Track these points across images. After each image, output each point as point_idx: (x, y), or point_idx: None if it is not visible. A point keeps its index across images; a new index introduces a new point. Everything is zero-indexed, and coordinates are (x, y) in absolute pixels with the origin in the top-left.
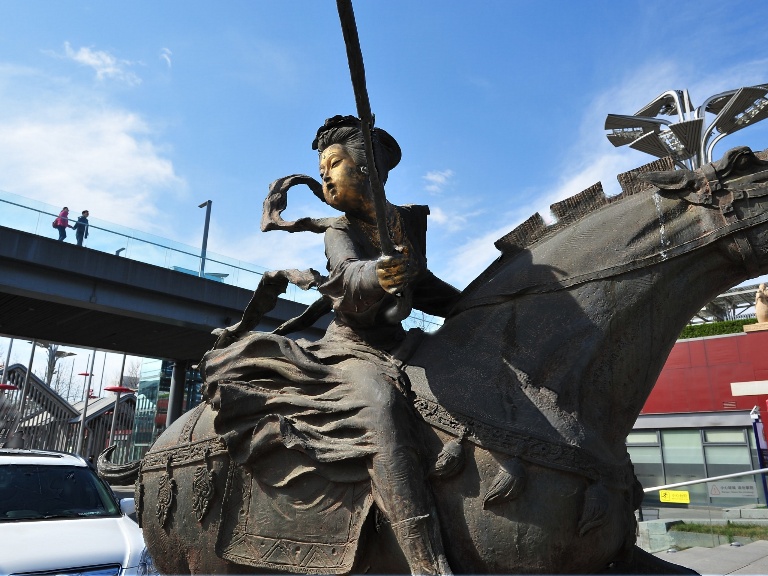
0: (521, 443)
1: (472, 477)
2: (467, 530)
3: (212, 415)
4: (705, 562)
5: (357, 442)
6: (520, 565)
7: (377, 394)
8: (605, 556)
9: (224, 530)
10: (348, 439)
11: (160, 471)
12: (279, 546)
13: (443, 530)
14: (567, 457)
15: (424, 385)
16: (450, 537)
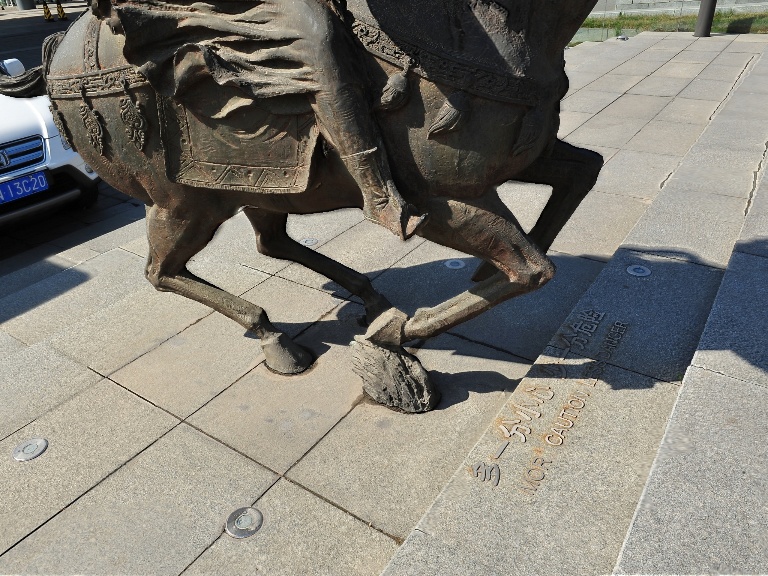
0: (468, 76)
1: (417, 109)
2: (412, 156)
3: (114, 38)
4: (590, 62)
5: (296, 77)
6: (458, 182)
7: (312, 25)
8: None
9: (170, 159)
10: (284, 70)
11: (76, 100)
12: (230, 171)
13: (389, 157)
14: (512, 89)
15: (362, 3)
16: (396, 162)
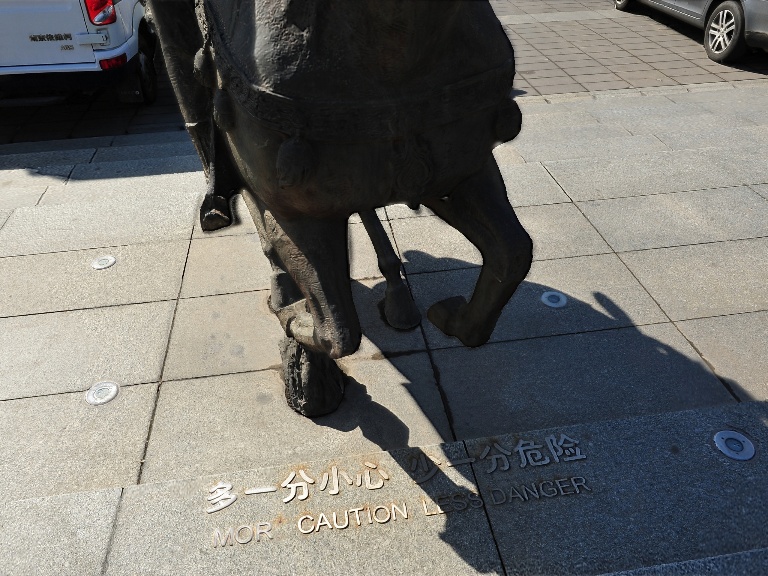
0: (223, 72)
1: None
2: None
3: None
4: None
5: None
6: None
7: None
8: (340, 207)
9: None
10: None
11: None
12: None
13: (220, 138)
14: (251, 103)
15: None
16: (227, 146)
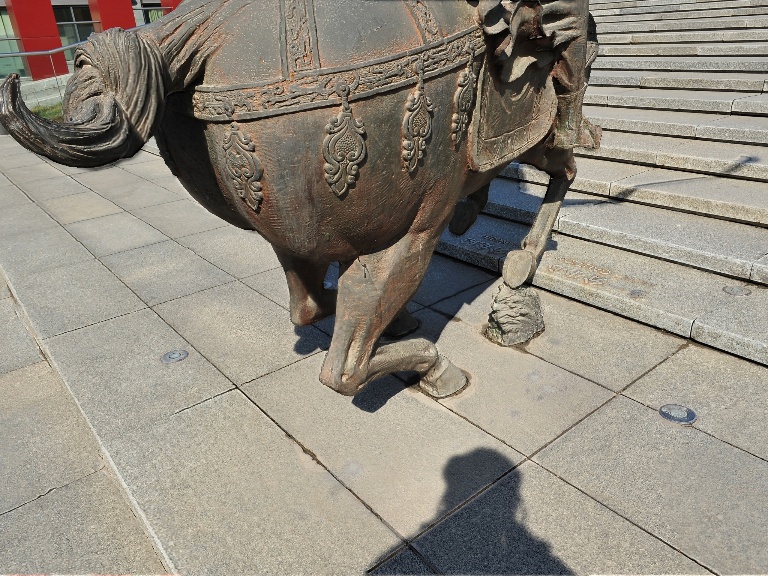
0: None
1: None
2: None
3: None
4: None
5: (565, 27)
6: None
7: None
8: None
9: None
10: (545, 25)
11: (402, 91)
12: None
13: None
14: None
15: None
16: None
